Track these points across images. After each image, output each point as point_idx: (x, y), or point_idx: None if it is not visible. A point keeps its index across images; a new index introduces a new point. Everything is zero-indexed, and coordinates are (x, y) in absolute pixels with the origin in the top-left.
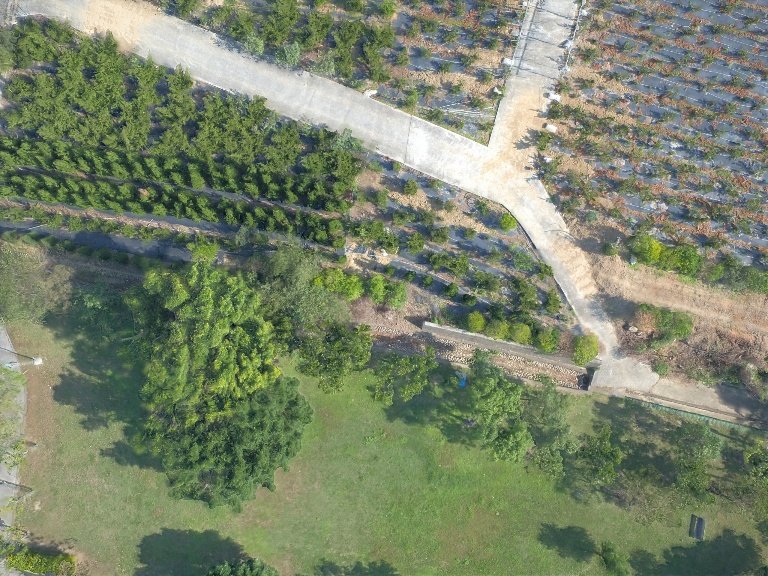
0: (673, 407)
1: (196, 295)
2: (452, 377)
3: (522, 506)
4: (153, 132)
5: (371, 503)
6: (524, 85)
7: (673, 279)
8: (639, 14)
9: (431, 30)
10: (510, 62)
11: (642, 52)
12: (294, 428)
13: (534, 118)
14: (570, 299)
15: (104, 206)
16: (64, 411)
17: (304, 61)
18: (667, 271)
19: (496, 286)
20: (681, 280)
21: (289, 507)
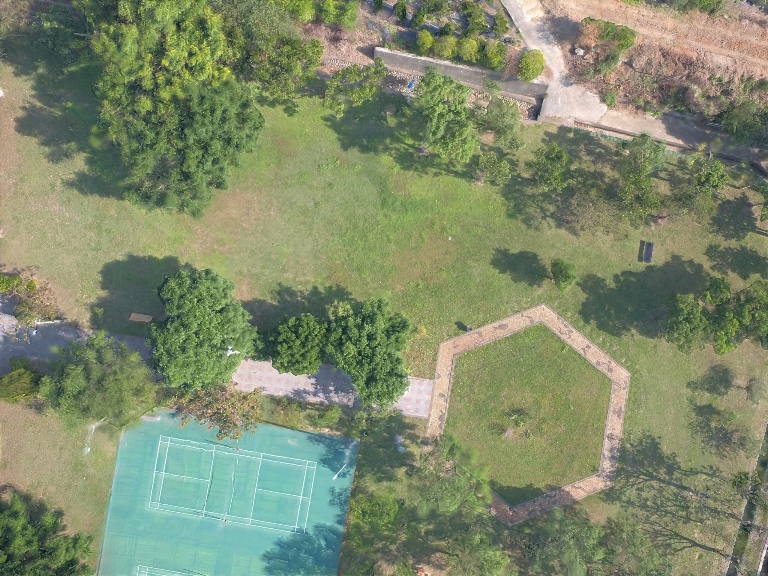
0: None
1: None
2: (404, 107)
3: (474, 231)
4: None
5: (326, 229)
6: None
7: None
8: None
9: None
10: None
11: None
12: (245, 132)
13: None
14: (517, 22)
15: None
16: (25, 142)
17: None
18: None
19: (443, 4)
20: (625, 0)
21: (246, 233)
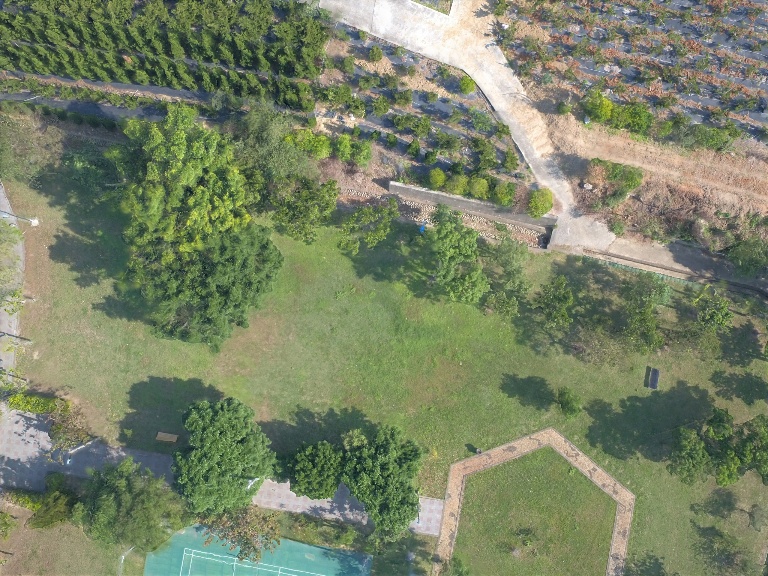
0: (629, 266)
1: (171, 137)
2: (417, 236)
3: (484, 357)
4: (137, 9)
5: (342, 353)
6: None
7: (625, 137)
8: None
9: None
10: None
11: None
12: (266, 272)
13: None
14: (527, 158)
15: (92, 76)
16: (59, 269)
17: None
18: (619, 129)
19: (456, 144)
20: (633, 138)
21: (266, 357)
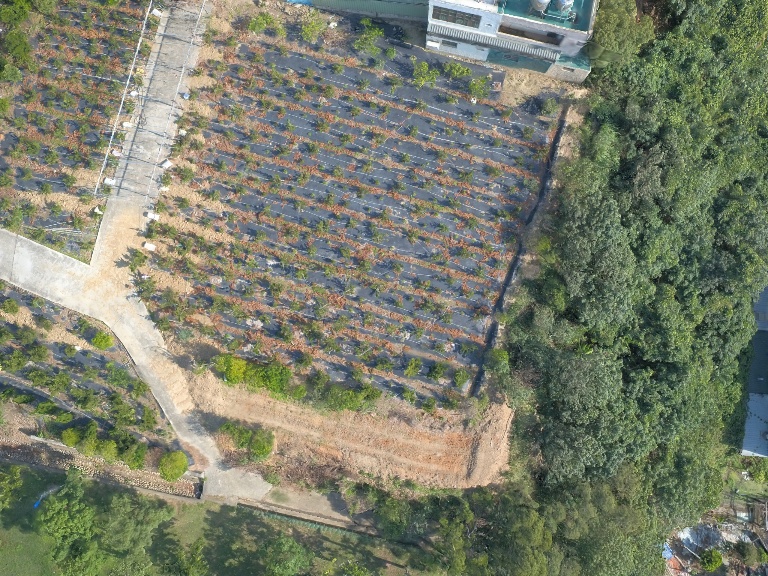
0: (289, 514)
1: None
2: None
3: None
4: None
5: None
6: (125, 204)
7: (265, 395)
8: (238, 132)
9: (33, 152)
10: (111, 182)
11: (241, 170)
12: None
13: (134, 237)
14: (168, 414)
15: None
16: None
17: None
18: (258, 388)
19: None
20: (273, 396)
21: None
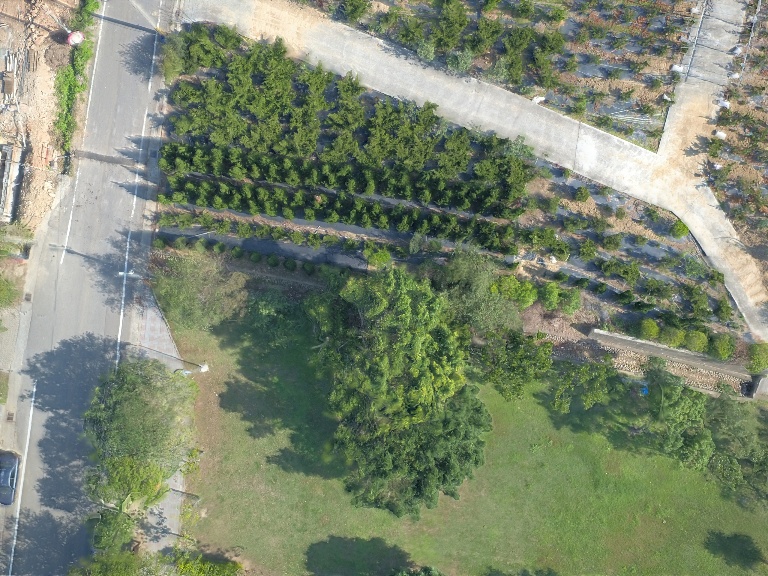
0: None
1: (395, 303)
2: (618, 384)
3: (689, 514)
4: (320, 139)
5: (538, 511)
6: (693, 92)
7: None
8: None
9: (600, 37)
10: (679, 69)
11: None
12: None
13: (703, 125)
14: (741, 306)
15: (275, 213)
16: (230, 418)
17: (471, 68)
18: None
19: (670, 293)
20: None
21: (456, 515)
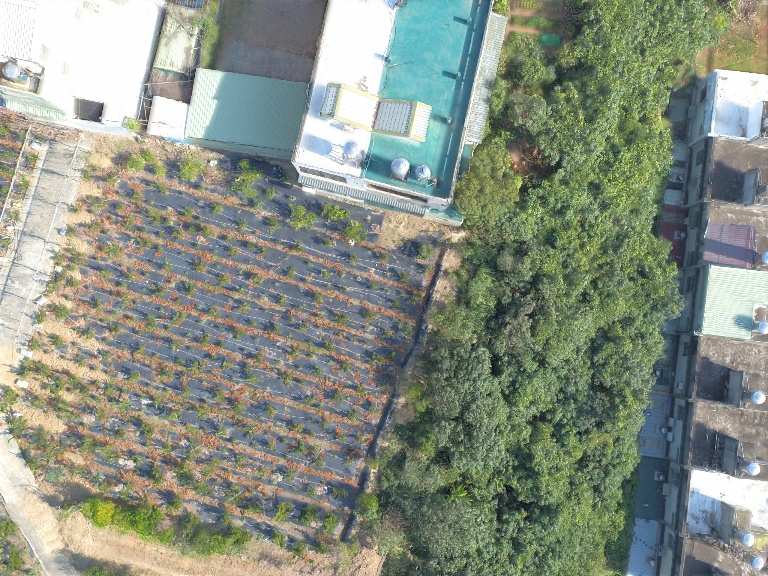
0: None
1: None
2: None
3: None
4: None
5: None
6: None
7: (136, 536)
8: (115, 269)
9: None
10: None
11: (116, 308)
12: None
13: (6, 373)
14: (37, 553)
15: None
16: None
17: None
18: (128, 529)
19: None
20: (143, 538)
21: None
